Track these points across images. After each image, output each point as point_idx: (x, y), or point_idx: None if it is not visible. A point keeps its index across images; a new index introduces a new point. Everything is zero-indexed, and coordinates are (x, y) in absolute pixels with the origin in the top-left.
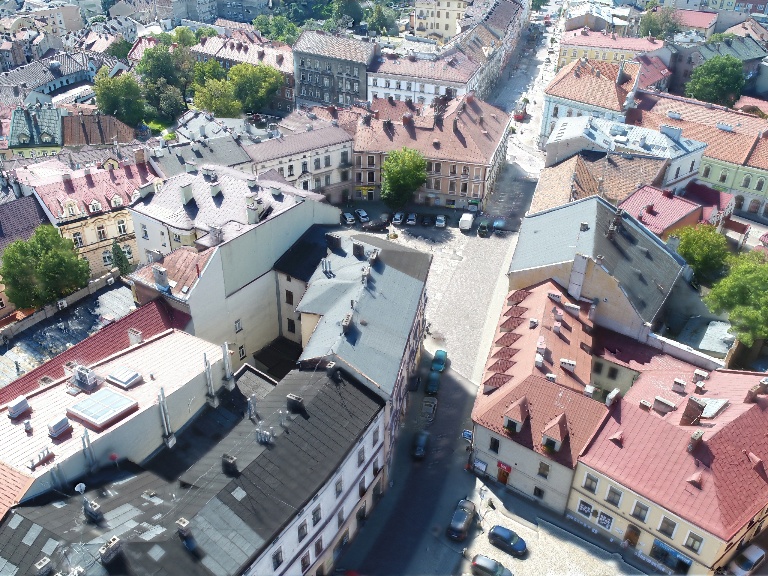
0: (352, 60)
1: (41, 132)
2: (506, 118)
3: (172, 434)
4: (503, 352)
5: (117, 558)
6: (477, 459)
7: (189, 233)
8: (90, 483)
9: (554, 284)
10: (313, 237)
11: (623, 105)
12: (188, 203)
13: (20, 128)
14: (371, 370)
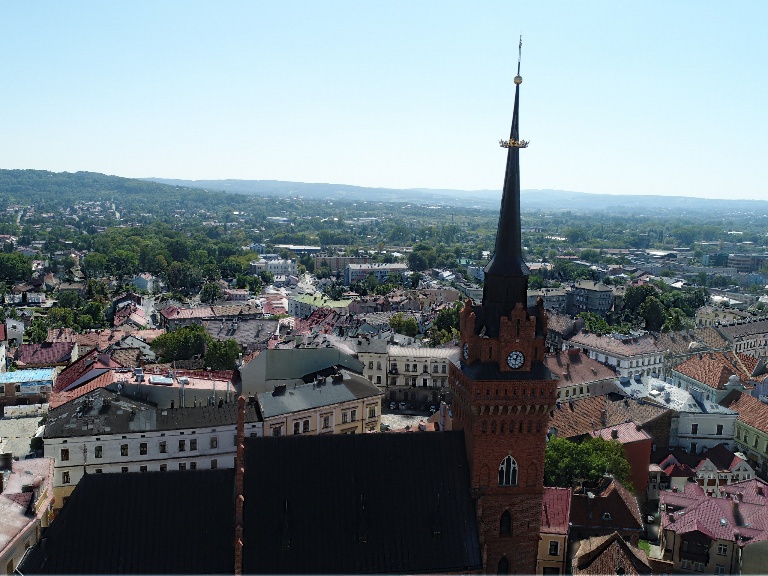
0: (554, 330)
1: None
2: (611, 375)
3: None
4: None
5: (108, 407)
6: None
7: None
8: (133, 398)
9: (435, 424)
10: None
11: (724, 385)
12: (298, 345)
13: None
14: (269, 406)
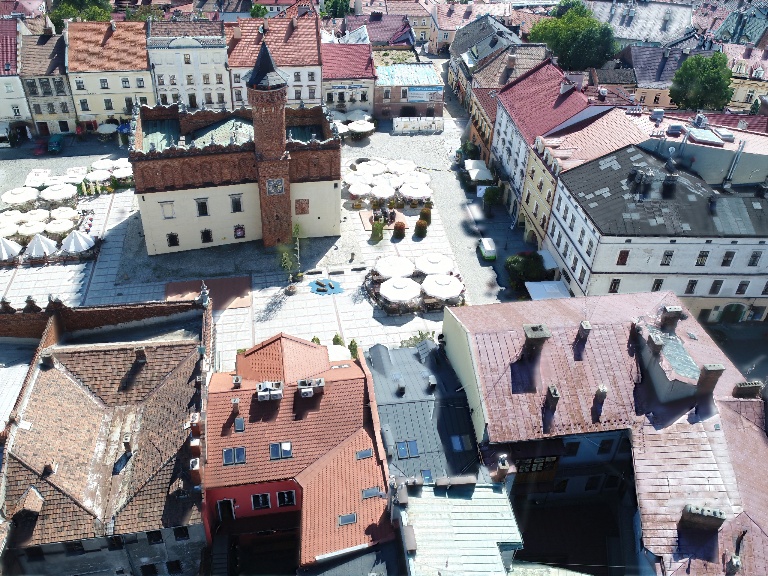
0: None
1: (743, 34)
2: None
3: (731, 181)
4: None
5: (671, 186)
6: None
7: None
8: None
9: None
10: None
11: None
12: None
13: (728, 27)
14: None
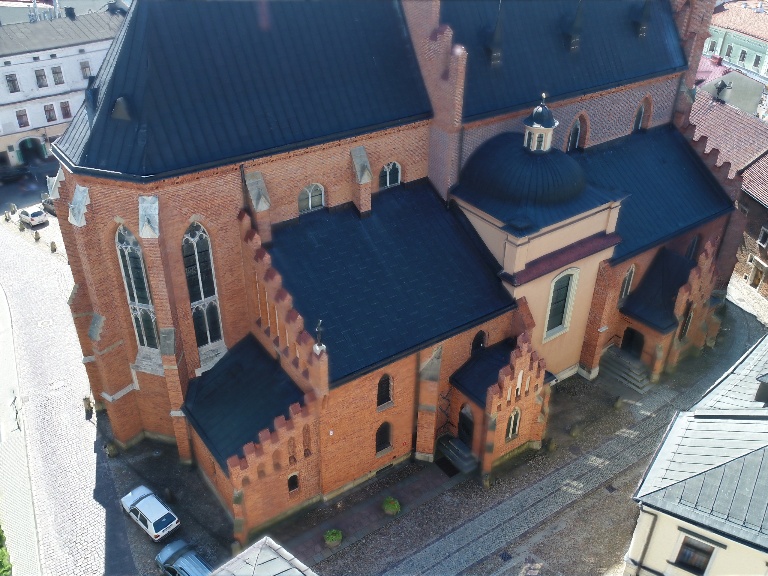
0: None
1: None
2: None
3: None
4: None
5: None
6: None
7: None
8: None
9: None
10: None
11: None
12: None
13: None
14: None
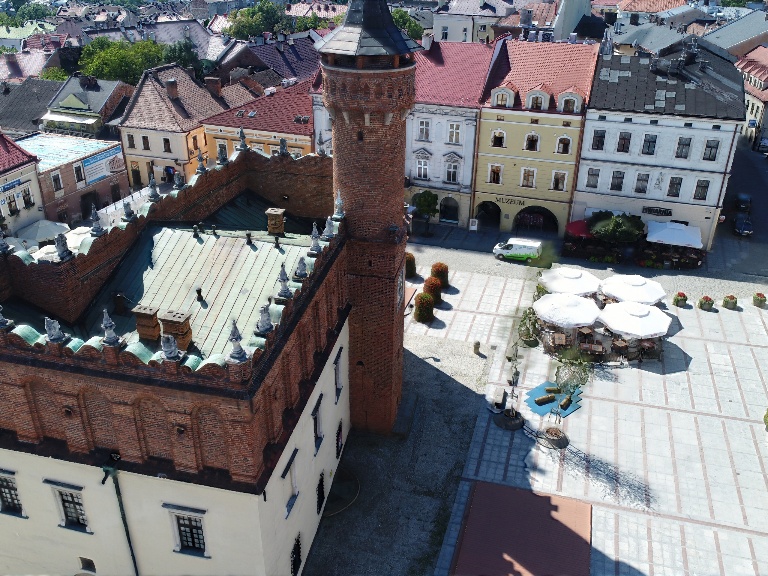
0: None
1: None
2: None
3: None
4: (762, 70)
5: None
6: (763, 138)
7: (495, 22)
8: None
9: (764, 47)
10: (589, 20)
11: None
12: (484, 5)
13: None
14: None
